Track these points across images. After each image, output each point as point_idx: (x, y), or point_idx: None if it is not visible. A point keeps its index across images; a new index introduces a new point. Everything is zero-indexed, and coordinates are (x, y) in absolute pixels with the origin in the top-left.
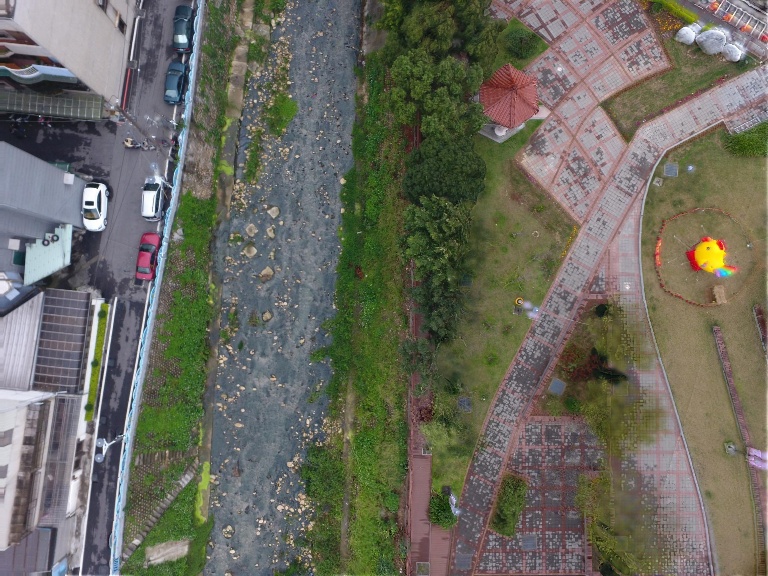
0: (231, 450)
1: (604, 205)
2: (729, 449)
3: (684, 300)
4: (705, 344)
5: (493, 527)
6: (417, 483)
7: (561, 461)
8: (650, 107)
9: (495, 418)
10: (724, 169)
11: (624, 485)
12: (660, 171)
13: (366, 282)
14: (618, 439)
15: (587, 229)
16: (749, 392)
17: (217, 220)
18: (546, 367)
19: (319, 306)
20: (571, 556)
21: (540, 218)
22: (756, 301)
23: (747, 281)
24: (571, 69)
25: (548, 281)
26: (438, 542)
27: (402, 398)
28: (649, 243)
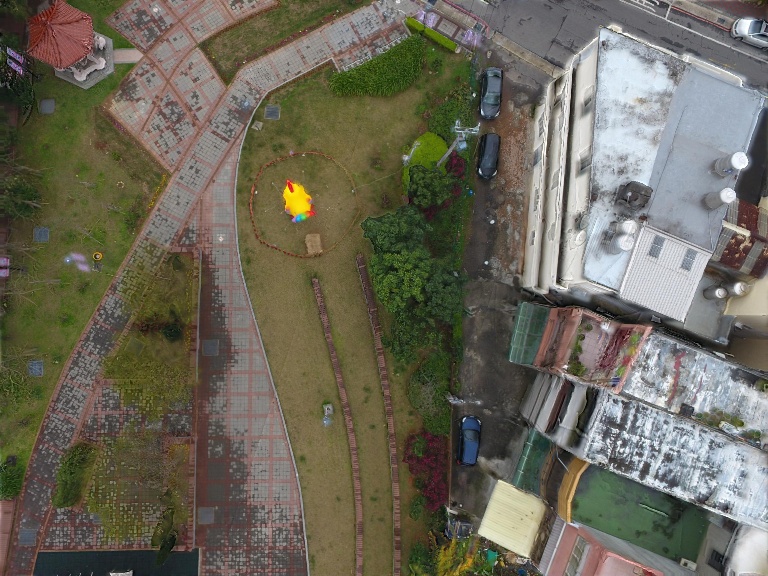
0: None
1: (197, 152)
2: None
3: (282, 251)
4: (304, 298)
5: None
6: None
7: (141, 427)
8: (252, 47)
9: (69, 382)
10: (324, 109)
11: (211, 452)
12: (260, 114)
13: None
14: (205, 402)
15: (178, 178)
16: (349, 349)
17: None
18: None
19: None
20: (147, 530)
21: (126, 168)
22: (360, 250)
23: (348, 229)
24: (168, 9)
25: (133, 234)
26: None
27: None
28: (245, 191)
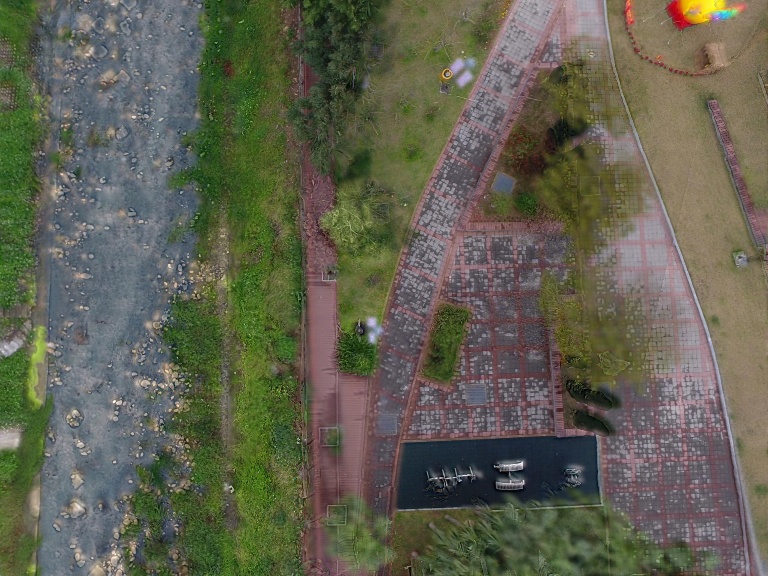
0: (77, 310)
1: None
2: (739, 260)
3: (667, 69)
4: (698, 125)
5: (423, 373)
6: (316, 319)
7: (514, 284)
8: None
9: (421, 230)
10: None
11: (602, 313)
12: None
13: (250, 78)
14: (590, 252)
15: None
16: (761, 184)
17: (54, 14)
18: (488, 160)
19: (192, 118)
20: (534, 411)
21: None
22: (762, 67)
23: (748, 40)
24: None
25: (485, 49)
26: (349, 399)
27: (293, 207)
28: None
